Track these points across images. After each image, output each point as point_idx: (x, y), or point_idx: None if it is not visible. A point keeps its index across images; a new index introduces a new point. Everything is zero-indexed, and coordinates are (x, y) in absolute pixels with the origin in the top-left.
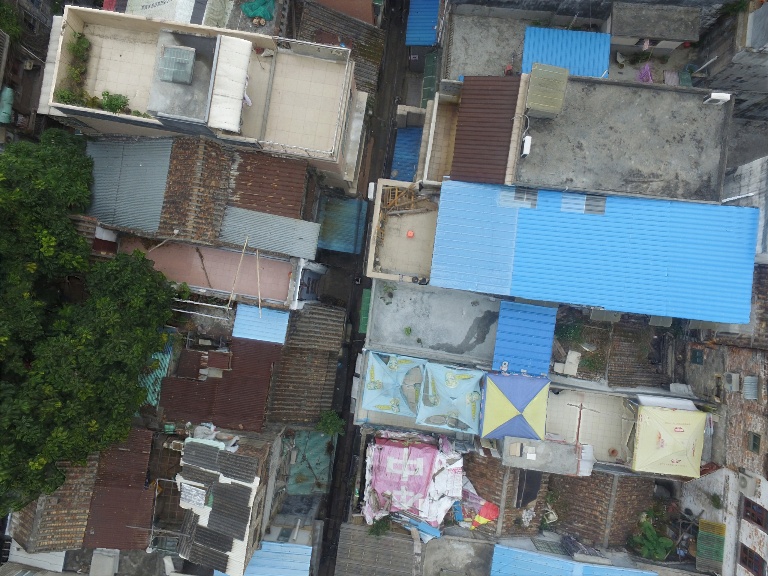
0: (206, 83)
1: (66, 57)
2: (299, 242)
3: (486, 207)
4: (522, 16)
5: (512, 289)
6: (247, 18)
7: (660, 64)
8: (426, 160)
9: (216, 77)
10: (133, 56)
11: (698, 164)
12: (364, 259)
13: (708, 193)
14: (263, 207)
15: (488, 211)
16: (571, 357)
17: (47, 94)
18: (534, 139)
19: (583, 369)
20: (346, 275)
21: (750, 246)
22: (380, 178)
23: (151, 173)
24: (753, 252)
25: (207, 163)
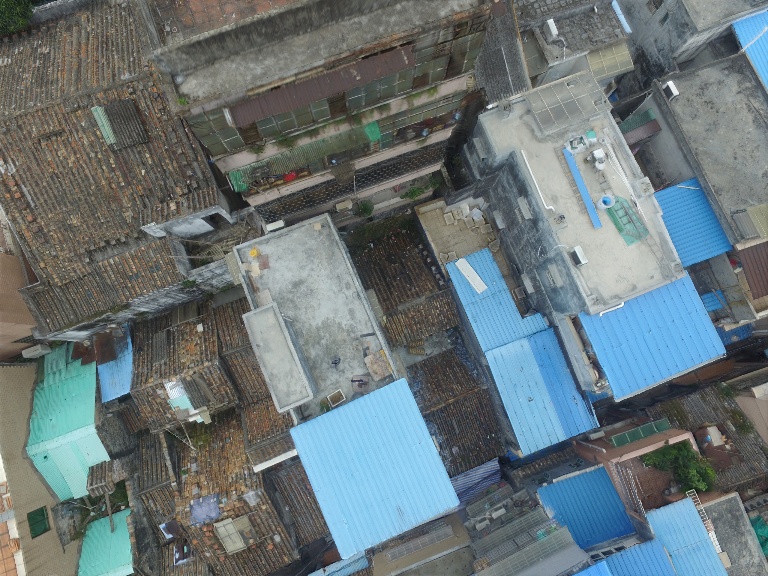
0: None
1: None
2: None
3: None
4: None
5: None
6: None
7: None
8: None
9: None
10: None
11: (720, 82)
12: None
13: (736, 65)
14: None
15: None
16: None
17: None
18: None
19: None
20: None
21: (762, 18)
22: None
23: None
24: (766, 14)
25: None
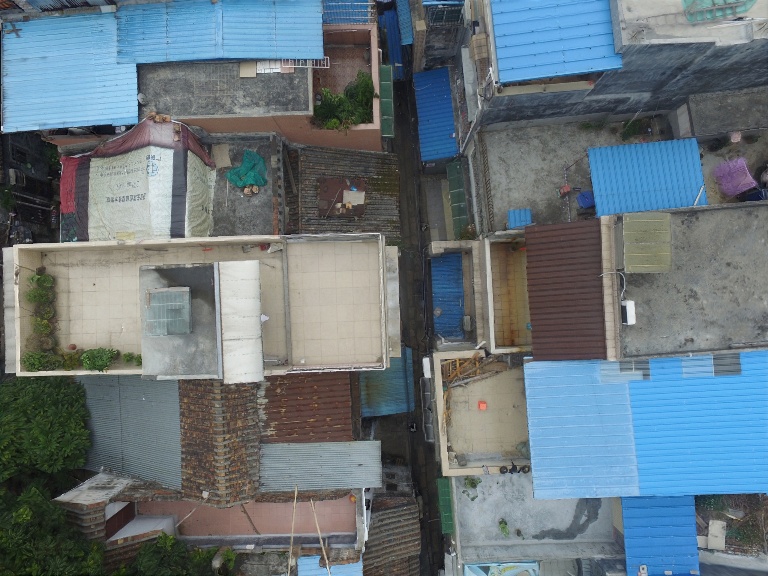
0: (211, 326)
1: (27, 308)
2: (359, 470)
3: (586, 388)
4: (568, 120)
5: (641, 488)
6: (236, 187)
7: (746, 144)
8: (489, 324)
9: (222, 317)
10: (109, 282)
11: None
12: (423, 422)
13: None
14: (306, 436)
15: (590, 392)
16: (714, 528)
17: (13, 347)
18: (633, 297)
19: (732, 541)
20: (398, 424)
21: None
22: (435, 352)
23: (158, 410)
24: None
25: (227, 401)
